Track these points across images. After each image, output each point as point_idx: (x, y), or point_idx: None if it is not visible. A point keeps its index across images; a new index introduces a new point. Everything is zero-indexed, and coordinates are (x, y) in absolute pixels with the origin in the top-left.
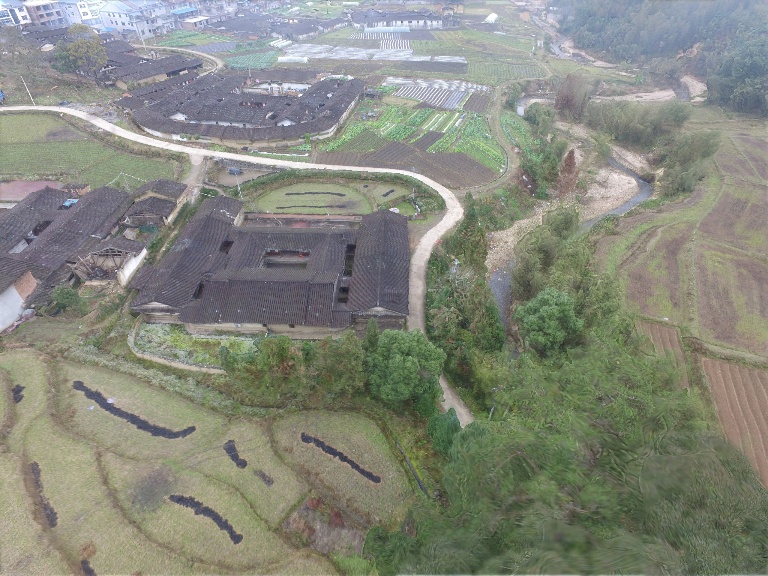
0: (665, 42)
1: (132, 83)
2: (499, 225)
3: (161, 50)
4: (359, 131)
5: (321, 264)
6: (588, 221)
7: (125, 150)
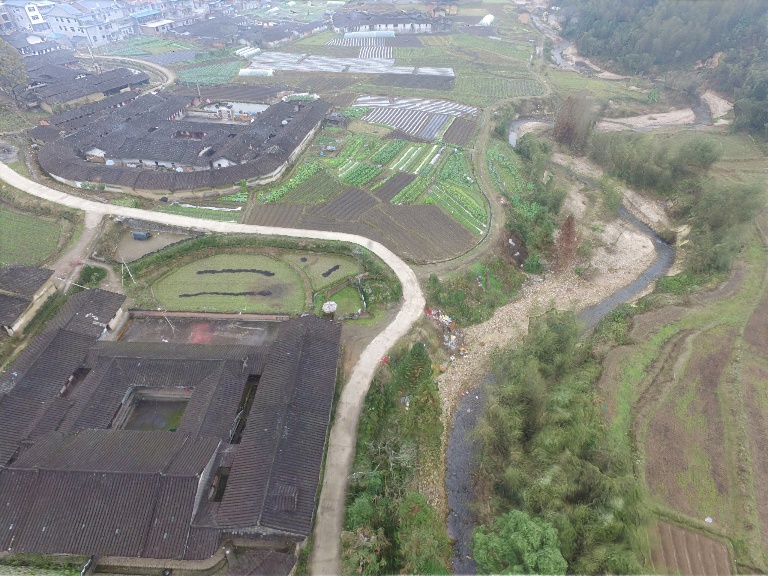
0: (681, 51)
1: (58, 105)
2: (474, 317)
3: (110, 60)
4: (311, 173)
5: (199, 421)
6: (592, 307)
7: (10, 204)
